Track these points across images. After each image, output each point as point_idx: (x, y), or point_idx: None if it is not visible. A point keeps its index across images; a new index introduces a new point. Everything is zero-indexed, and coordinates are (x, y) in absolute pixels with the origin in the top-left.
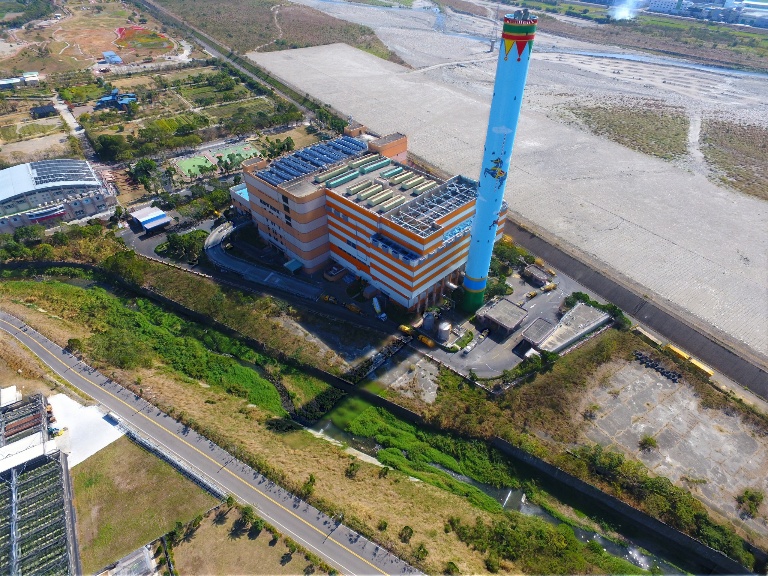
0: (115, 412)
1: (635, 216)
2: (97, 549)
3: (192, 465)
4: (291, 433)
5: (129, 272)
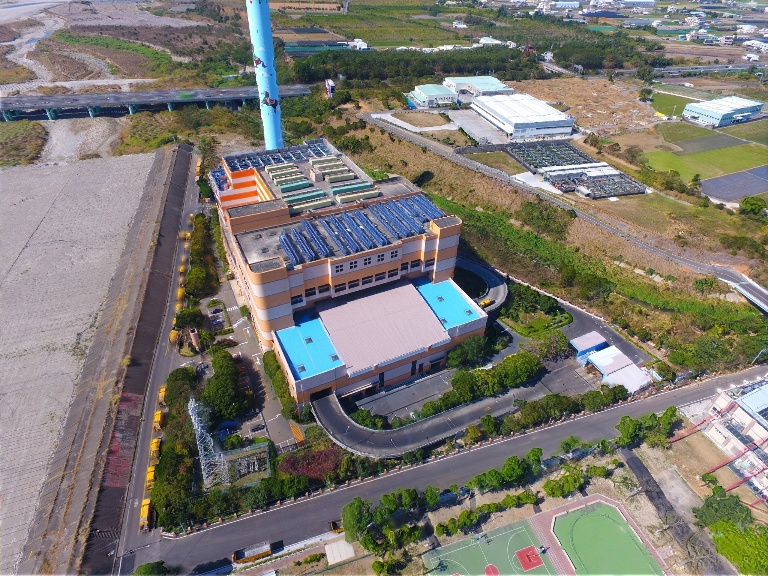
0: (520, 183)
1: (7, 247)
2: (503, 155)
3: (474, 164)
4: (429, 181)
5: (574, 269)
